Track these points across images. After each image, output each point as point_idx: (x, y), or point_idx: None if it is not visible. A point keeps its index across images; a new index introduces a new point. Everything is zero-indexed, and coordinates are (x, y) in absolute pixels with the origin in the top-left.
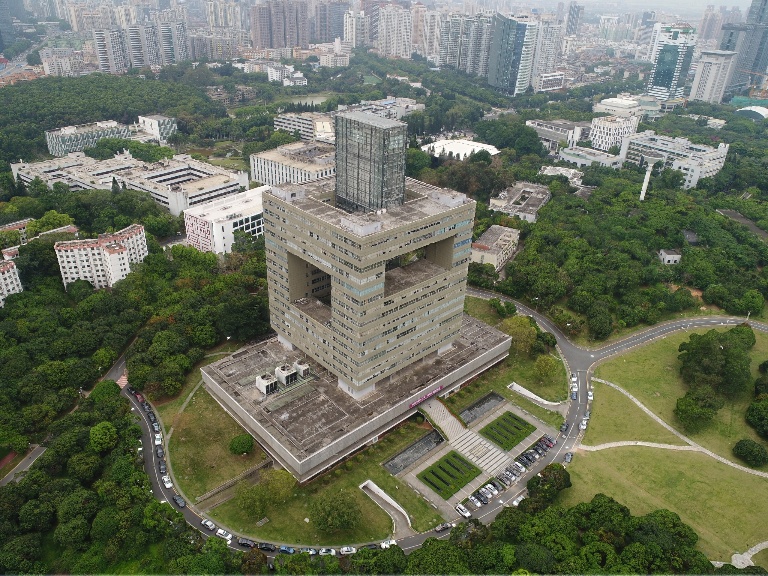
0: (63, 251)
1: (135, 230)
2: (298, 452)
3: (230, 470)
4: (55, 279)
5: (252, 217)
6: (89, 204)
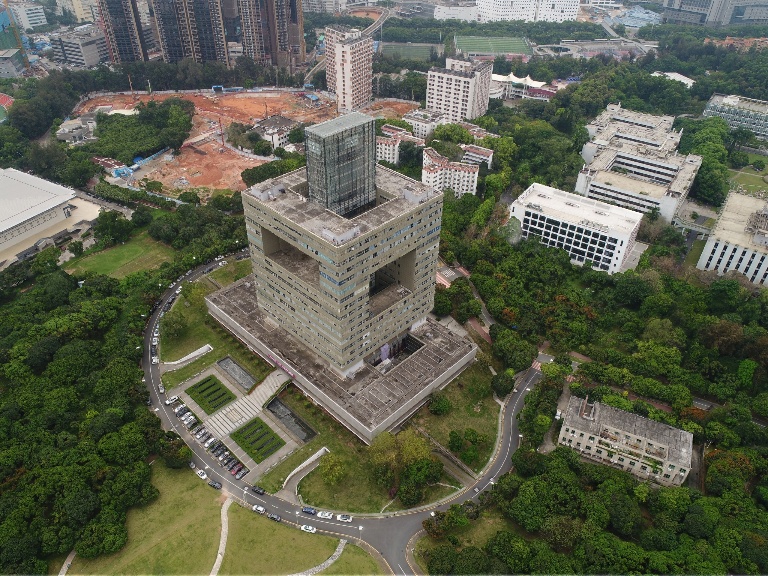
0: (424, 154)
1: None
2: (214, 295)
3: None
4: (421, 170)
5: (549, 219)
6: None
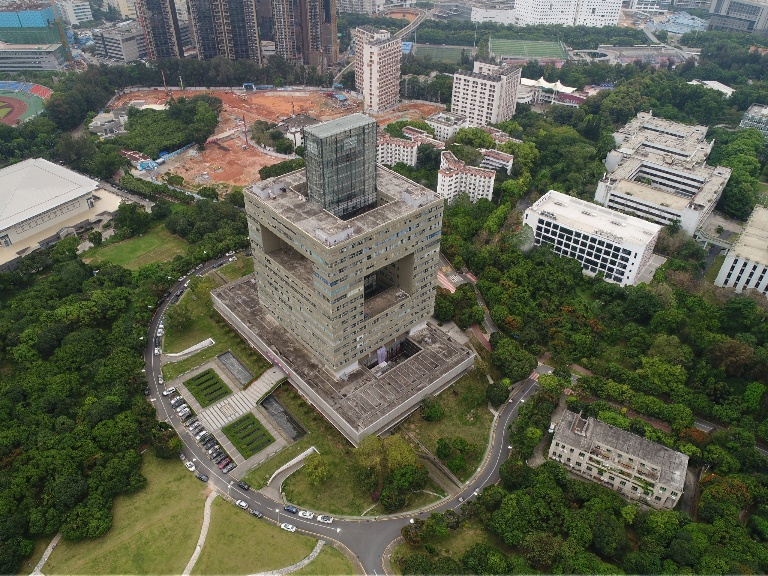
0: None
1: (485, 173)
2: (219, 290)
3: None
4: None
5: (563, 228)
6: None
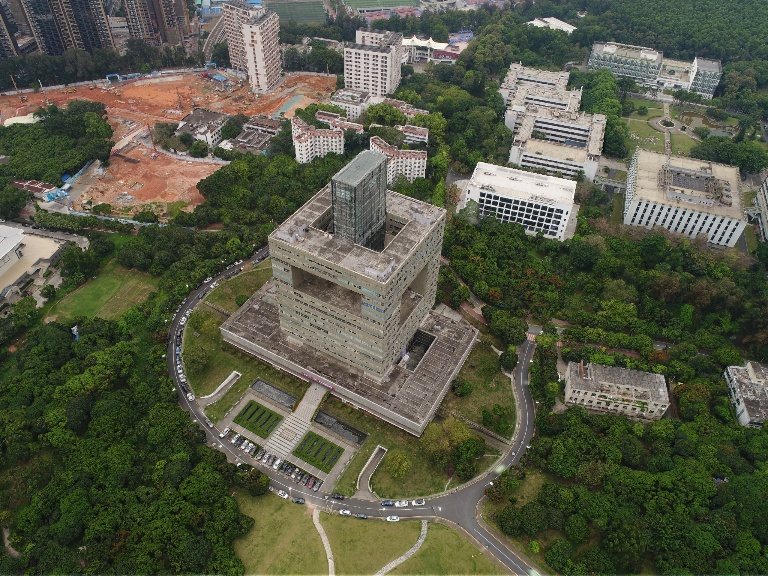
0: None
1: (418, 155)
2: (228, 323)
3: (231, 306)
4: None
5: (503, 198)
6: (469, 120)
